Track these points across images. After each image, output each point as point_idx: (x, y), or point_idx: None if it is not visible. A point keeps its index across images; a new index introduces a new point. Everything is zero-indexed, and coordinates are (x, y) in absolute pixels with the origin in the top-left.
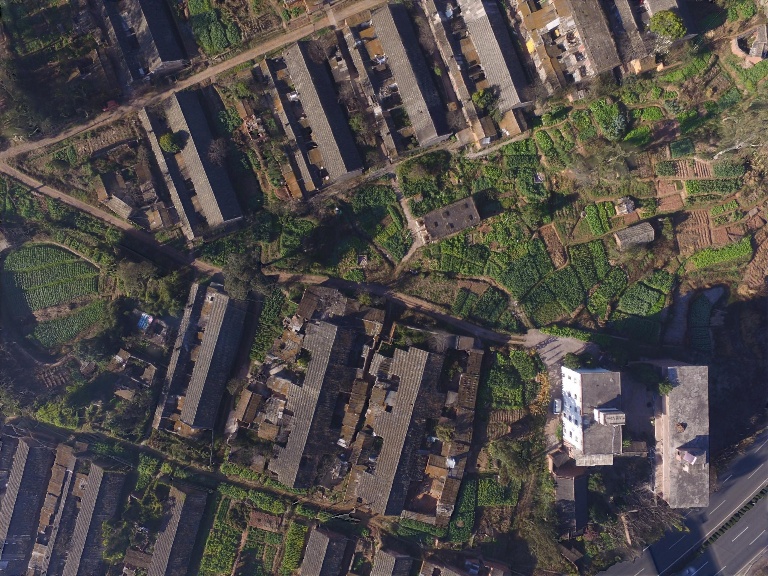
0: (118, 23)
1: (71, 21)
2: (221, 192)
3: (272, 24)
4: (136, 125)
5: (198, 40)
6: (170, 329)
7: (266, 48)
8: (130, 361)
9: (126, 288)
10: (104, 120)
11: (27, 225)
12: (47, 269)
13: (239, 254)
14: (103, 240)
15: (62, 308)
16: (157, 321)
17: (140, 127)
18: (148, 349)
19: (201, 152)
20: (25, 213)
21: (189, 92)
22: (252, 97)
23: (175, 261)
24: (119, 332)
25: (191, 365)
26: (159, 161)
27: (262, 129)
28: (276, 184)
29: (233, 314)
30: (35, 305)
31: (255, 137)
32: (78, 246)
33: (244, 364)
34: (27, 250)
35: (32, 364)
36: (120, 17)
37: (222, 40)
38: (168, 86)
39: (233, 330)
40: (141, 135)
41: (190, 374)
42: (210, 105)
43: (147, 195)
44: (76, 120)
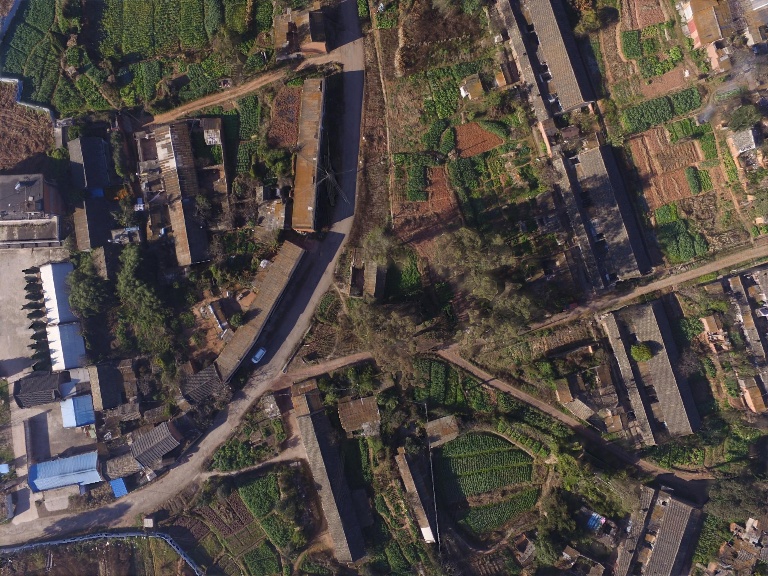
0: (589, 229)
1: (534, 221)
2: (687, 403)
3: (739, 238)
4: (593, 326)
5: (665, 249)
6: (619, 530)
7: (731, 261)
8: (579, 560)
9: (640, 516)
10: (561, 319)
11: (475, 416)
12: (482, 456)
13: (742, 483)
14: (547, 434)
15: (495, 495)
16: (607, 522)
17: (596, 328)
18: (591, 546)
19: (672, 364)
20: (477, 406)
21: (659, 302)
22: (722, 311)
23: (621, 460)
24: (578, 535)
25: (635, 565)
26: (623, 367)
27: (728, 342)
28: (733, 394)
29: (691, 522)
30: (468, 491)
31: (717, 348)
32: (519, 437)
33: (685, 566)
34: (466, 437)
35: (467, 551)
36: (590, 223)
37: (690, 252)
38: (628, 290)
39: (688, 537)
40: (597, 336)
41: (636, 575)
42: (669, 311)
43: (607, 399)
44: (533, 318)
